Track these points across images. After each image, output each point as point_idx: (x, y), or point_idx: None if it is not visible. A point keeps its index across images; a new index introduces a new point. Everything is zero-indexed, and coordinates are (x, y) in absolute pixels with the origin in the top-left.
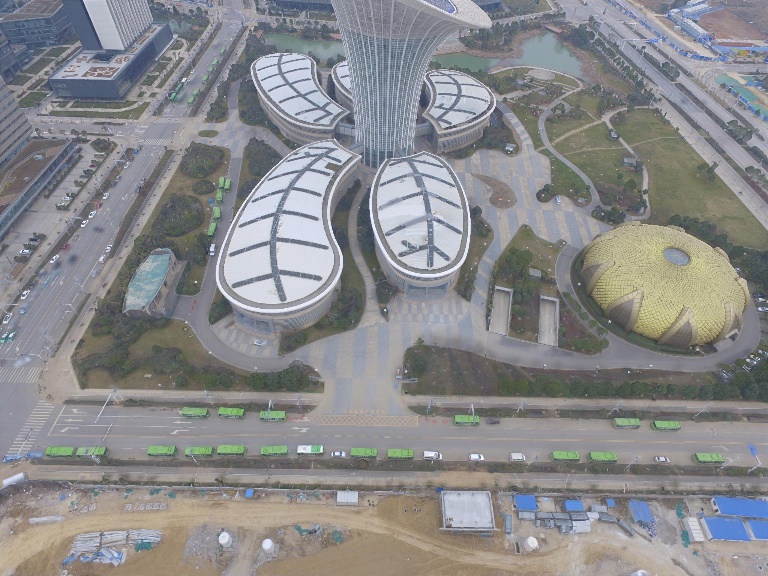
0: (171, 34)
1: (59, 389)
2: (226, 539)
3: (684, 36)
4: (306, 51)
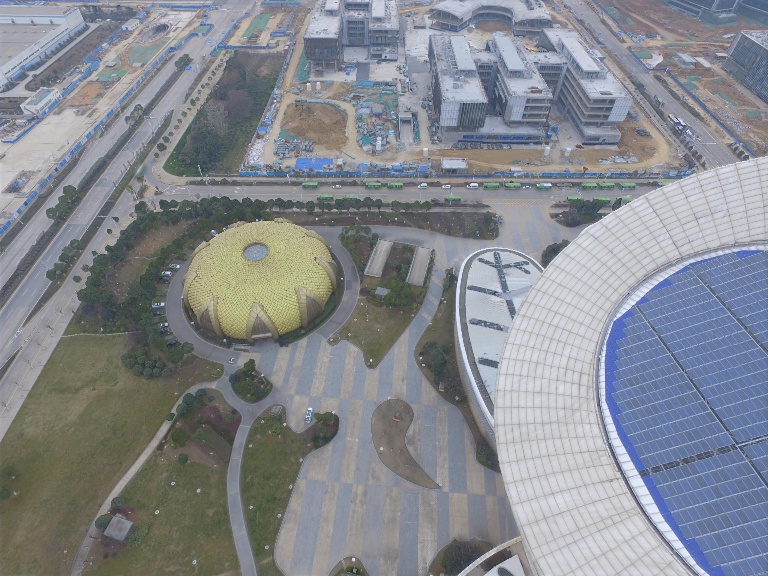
0: None
1: None
2: None
3: None
4: None
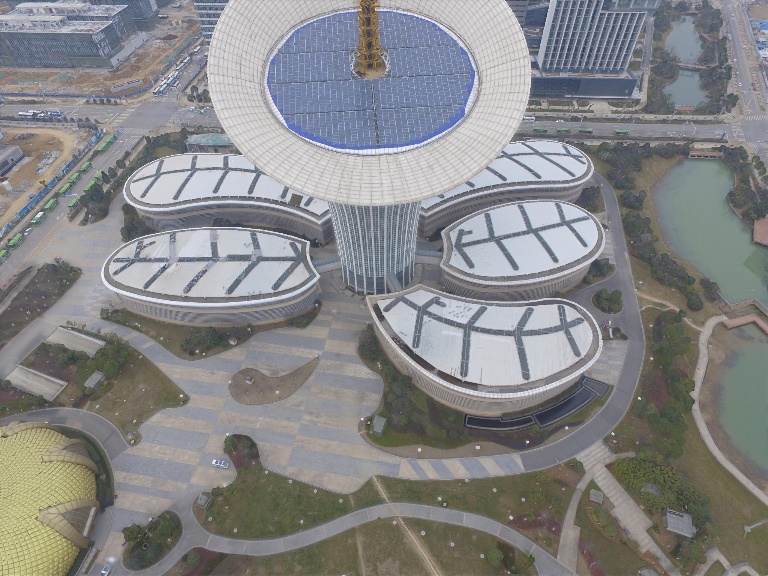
0: (631, 91)
1: (155, 133)
2: (4, 183)
3: None
4: (714, 209)
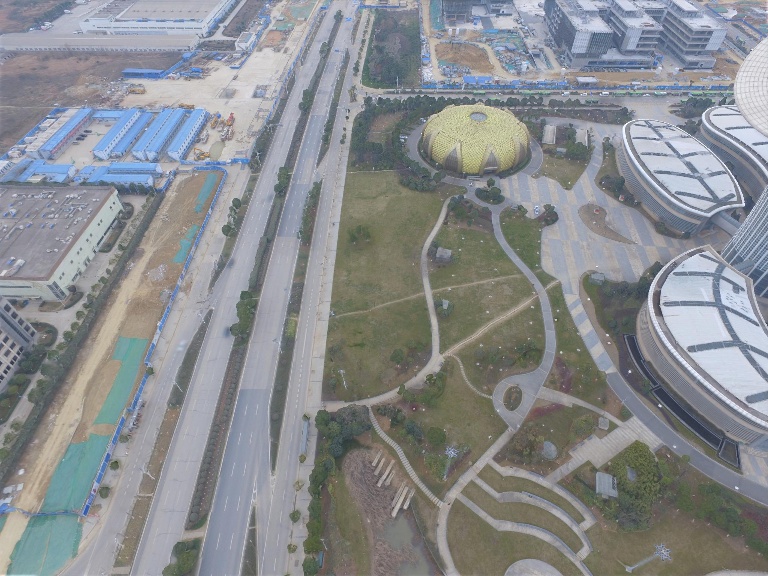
0: None
1: None
2: (676, 68)
3: None
4: None
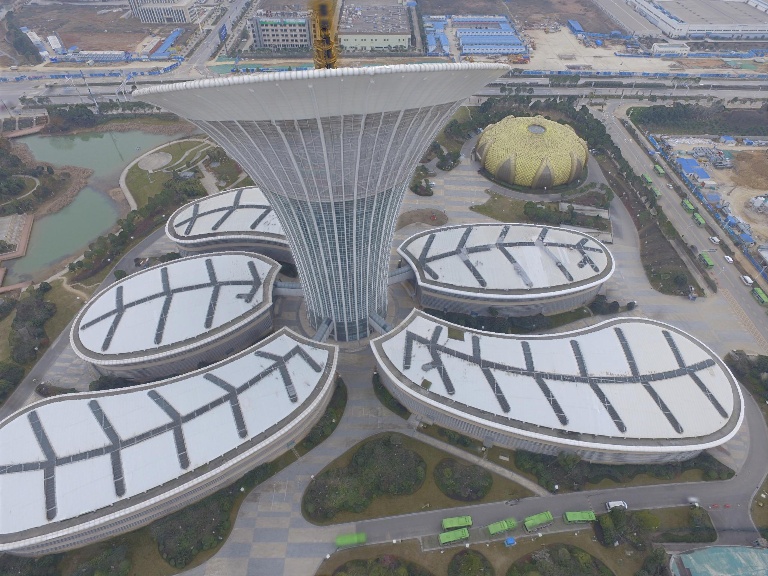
0: None
1: None
2: None
3: (112, 64)
4: None
